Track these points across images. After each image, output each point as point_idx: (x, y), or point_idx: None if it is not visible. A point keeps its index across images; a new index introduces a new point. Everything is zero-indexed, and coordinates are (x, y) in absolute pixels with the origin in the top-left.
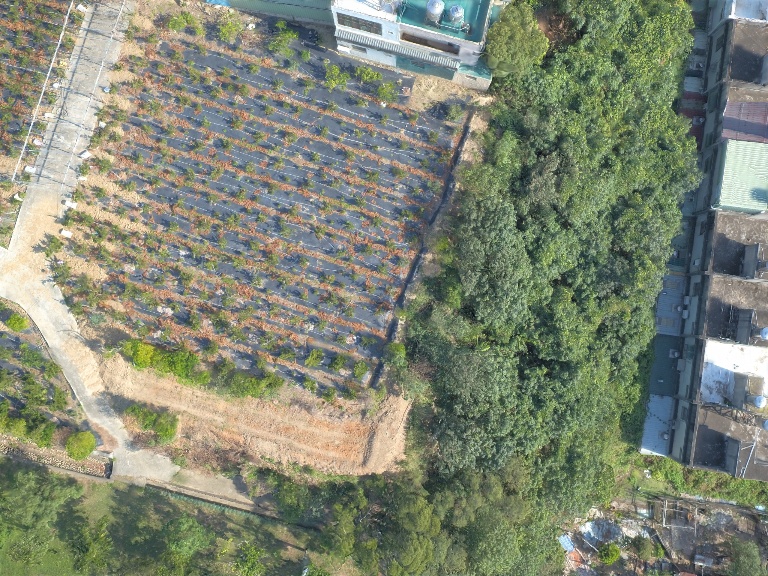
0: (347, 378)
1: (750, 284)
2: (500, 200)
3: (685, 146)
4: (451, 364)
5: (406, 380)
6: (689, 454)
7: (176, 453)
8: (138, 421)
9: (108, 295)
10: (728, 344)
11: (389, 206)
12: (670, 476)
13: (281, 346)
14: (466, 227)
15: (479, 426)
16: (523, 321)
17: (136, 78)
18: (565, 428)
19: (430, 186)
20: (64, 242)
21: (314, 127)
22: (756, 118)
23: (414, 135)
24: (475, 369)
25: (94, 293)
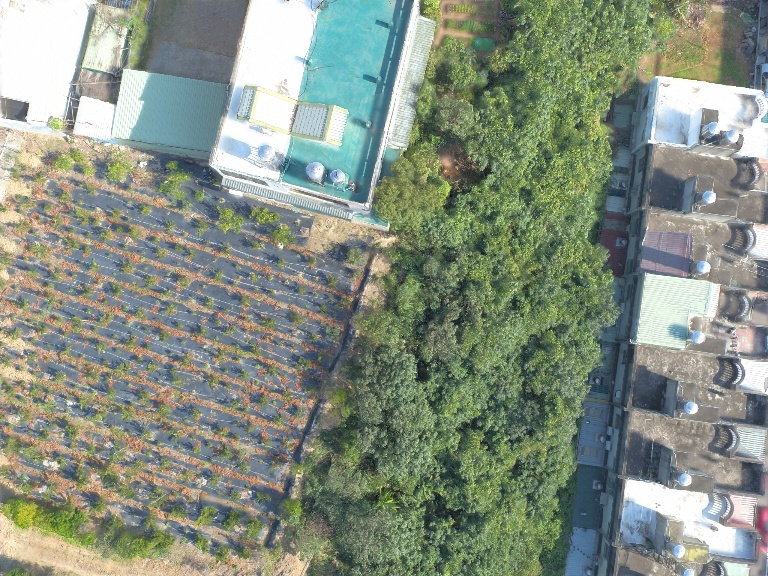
0: (242, 535)
1: (672, 419)
2: (403, 346)
3: (601, 280)
4: (348, 525)
5: None
6: None
7: None
8: None
9: None
10: (649, 482)
11: (286, 353)
12: None
13: (173, 501)
14: (361, 383)
15: None
16: (428, 472)
17: (22, 218)
18: None
19: (328, 333)
20: None
21: (208, 270)
22: (675, 250)
23: (312, 278)
24: (371, 534)
25: None
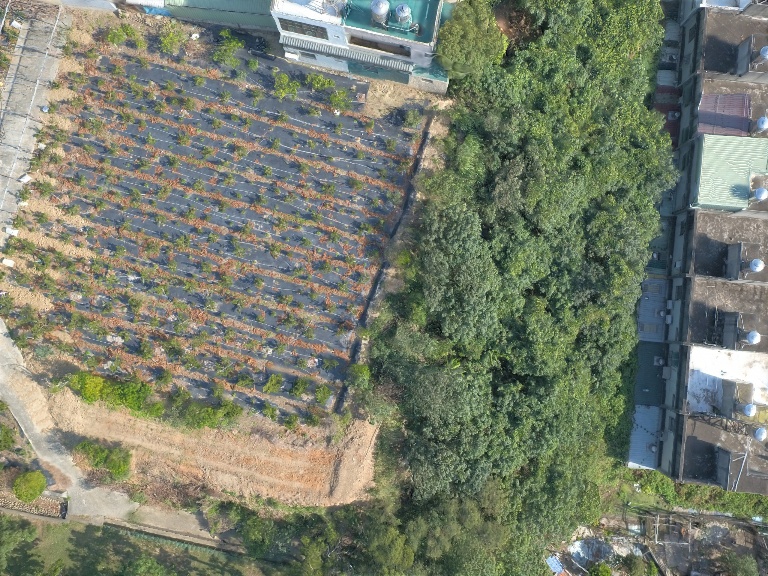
0: (310, 403)
1: (735, 285)
2: (464, 208)
3: (659, 143)
4: (418, 385)
5: (370, 404)
6: (678, 468)
7: (134, 489)
8: (88, 459)
9: (54, 326)
10: (714, 349)
11: (347, 220)
12: (661, 489)
13: (239, 372)
14: (427, 239)
15: (451, 449)
16: (494, 335)
17: (76, 96)
18: (544, 447)
19: (389, 197)
20: (6, 271)
21: (265, 139)
22: (733, 110)
23: (371, 144)
24: (443, 390)
25: (39, 324)
